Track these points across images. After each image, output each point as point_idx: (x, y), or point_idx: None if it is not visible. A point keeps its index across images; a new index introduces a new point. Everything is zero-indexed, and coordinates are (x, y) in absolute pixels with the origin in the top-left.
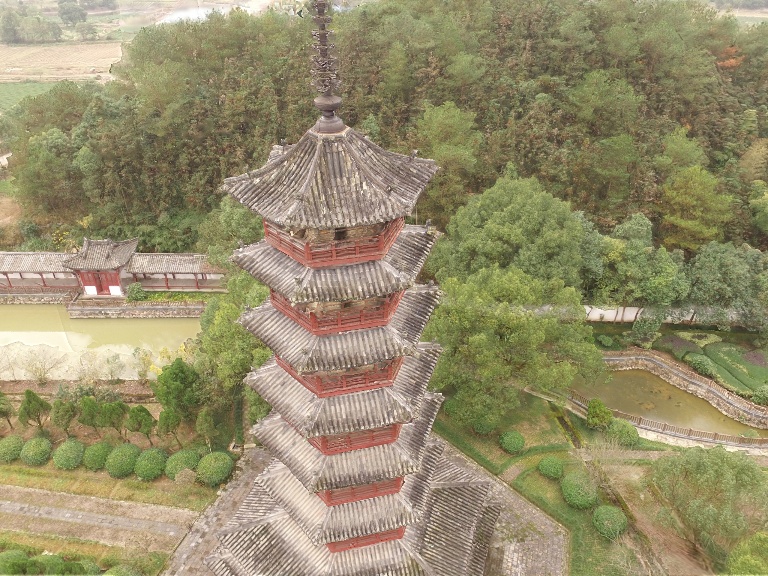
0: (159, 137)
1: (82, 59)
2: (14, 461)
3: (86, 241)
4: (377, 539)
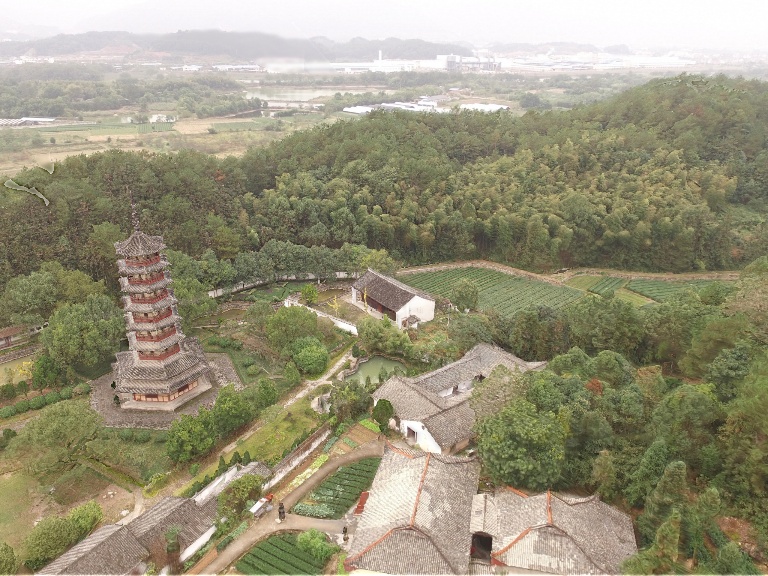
0: None
1: None
2: None
3: None
4: (173, 352)
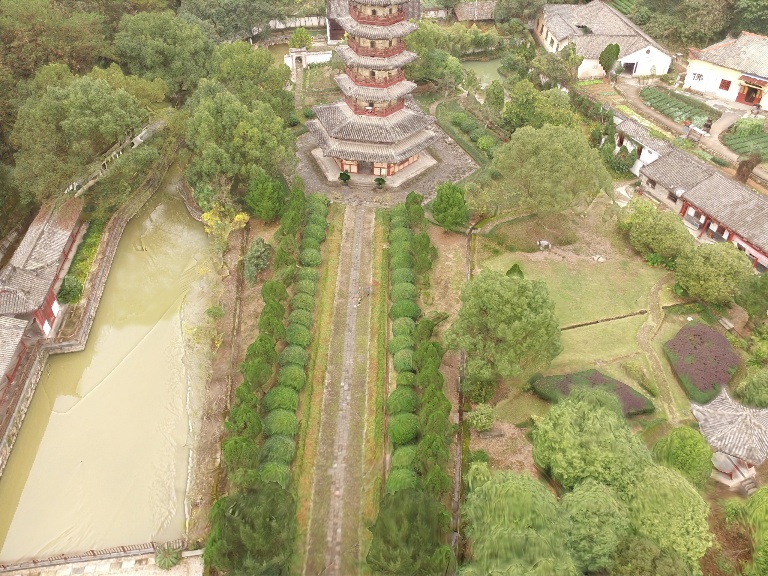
0: None
1: None
2: None
3: None
4: None
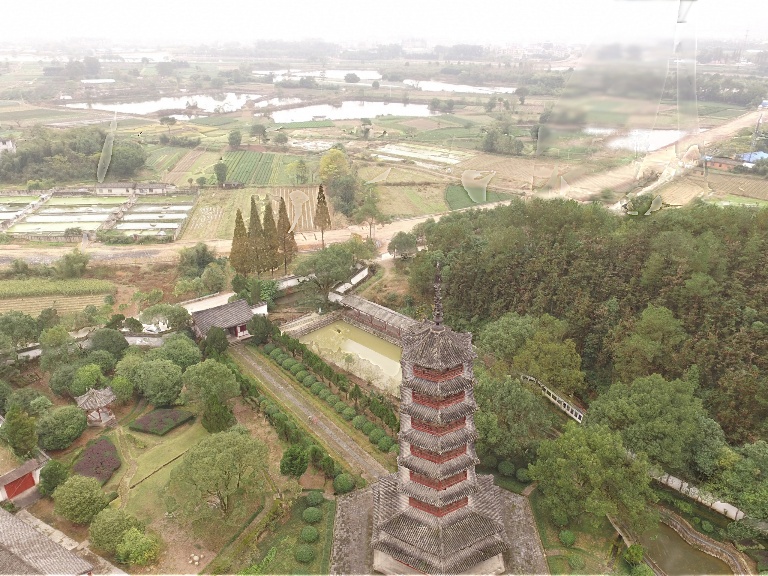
0: (490, 271)
1: (525, 173)
2: (340, 413)
3: (427, 318)
4: (429, 510)
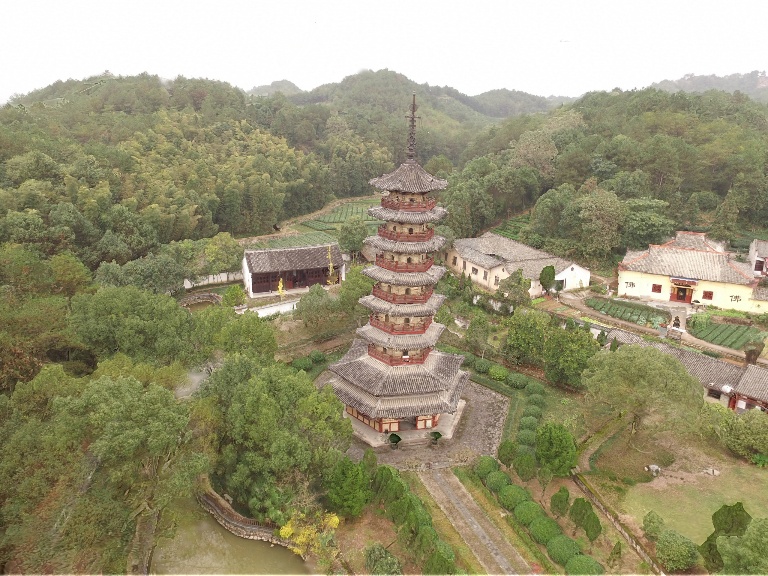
0: None
1: None
2: None
3: None
4: None
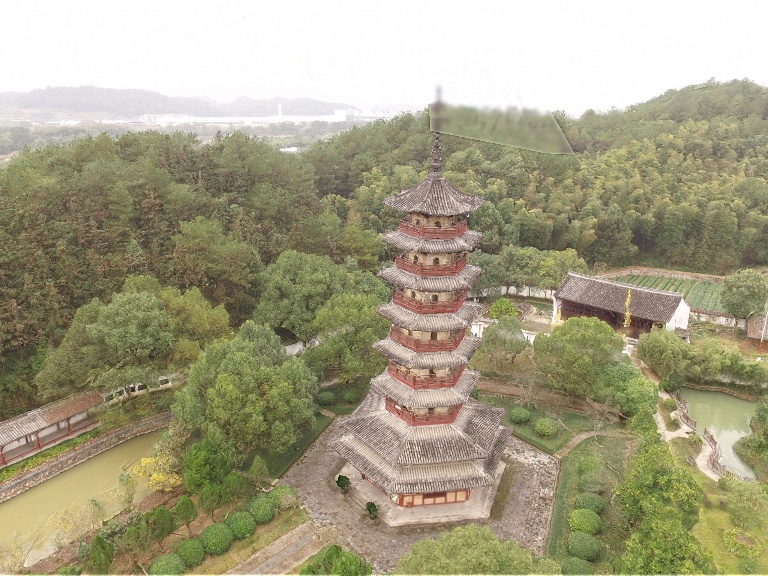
0: None
1: None
2: None
3: None
4: (460, 406)
